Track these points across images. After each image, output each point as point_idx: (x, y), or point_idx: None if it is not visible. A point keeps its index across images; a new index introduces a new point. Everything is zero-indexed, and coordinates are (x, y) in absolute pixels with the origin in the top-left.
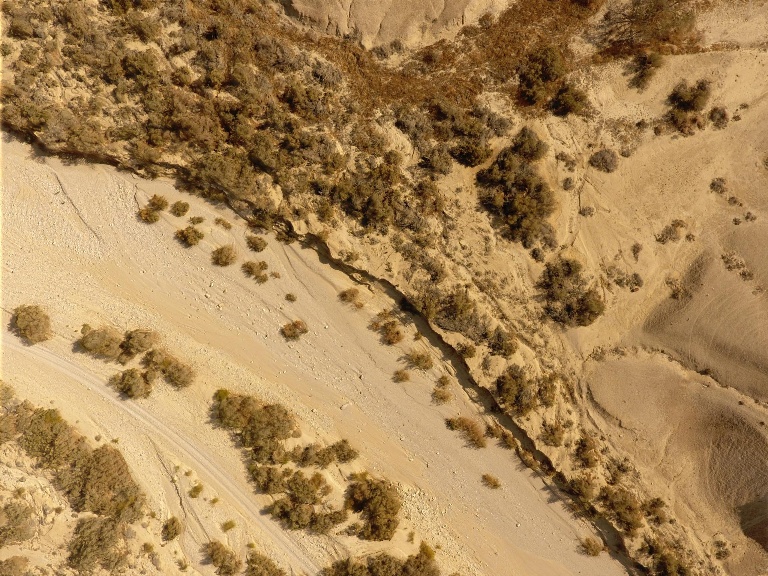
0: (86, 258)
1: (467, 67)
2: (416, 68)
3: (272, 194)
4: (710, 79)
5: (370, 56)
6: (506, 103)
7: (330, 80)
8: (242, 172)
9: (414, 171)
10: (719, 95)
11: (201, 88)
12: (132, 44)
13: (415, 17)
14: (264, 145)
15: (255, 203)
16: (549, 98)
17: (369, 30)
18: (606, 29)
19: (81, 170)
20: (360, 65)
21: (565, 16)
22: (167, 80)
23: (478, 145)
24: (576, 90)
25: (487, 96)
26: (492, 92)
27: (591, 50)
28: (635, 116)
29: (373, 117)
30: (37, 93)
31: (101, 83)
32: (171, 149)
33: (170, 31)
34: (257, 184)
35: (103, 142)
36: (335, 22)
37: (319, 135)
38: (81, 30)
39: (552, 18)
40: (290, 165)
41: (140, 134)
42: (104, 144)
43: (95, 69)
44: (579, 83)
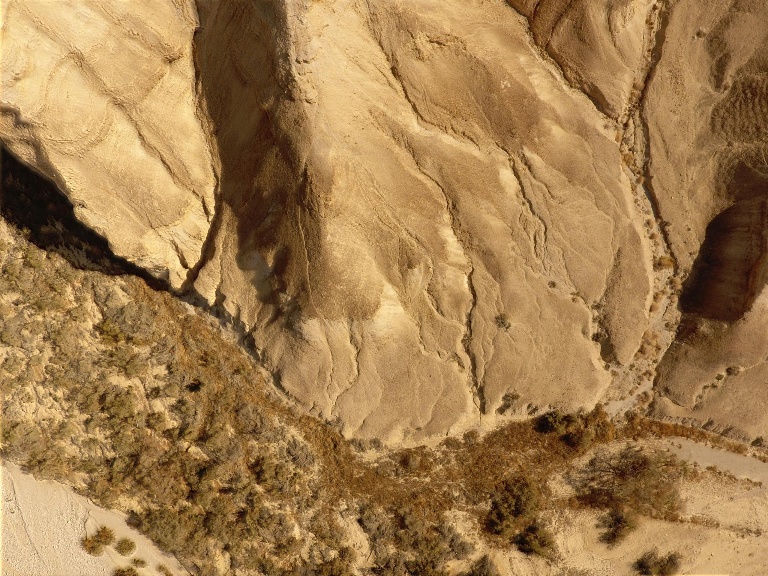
0: (22, 575)
1: (442, 479)
2: (391, 469)
3: (220, 563)
4: (683, 553)
5: (348, 445)
6: (473, 526)
7: (302, 463)
8: (194, 537)
9: (366, 574)
10: (689, 570)
11: (173, 438)
12: (115, 378)
13: (400, 422)
14: (222, 517)
15: (201, 568)
16: (517, 531)
17: (351, 423)
18: (589, 474)
19: (38, 482)
20: (336, 452)
21: (550, 451)
22: (141, 425)
23: (435, 567)
24: (546, 530)
25: (456, 514)
26: (462, 511)
27: (570, 491)
28: (600, 571)
29: (337, 508)
30: (10, 408)
31: (76, 409)
32: (129, 494)
33: (156, 373)
34: (207, 550)
35: (64, 470)
36: (319, 408)
37: (279, 515)
38: (68, 357)
39: (537, 450)
40: (244, 537)
41: (102, 471)
42: (65, 472)
43: (73, 395)
44: (550, 524)
